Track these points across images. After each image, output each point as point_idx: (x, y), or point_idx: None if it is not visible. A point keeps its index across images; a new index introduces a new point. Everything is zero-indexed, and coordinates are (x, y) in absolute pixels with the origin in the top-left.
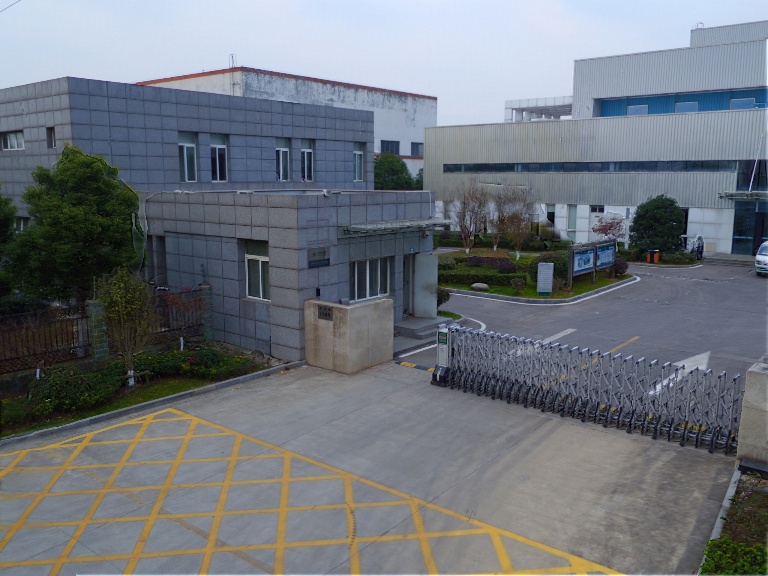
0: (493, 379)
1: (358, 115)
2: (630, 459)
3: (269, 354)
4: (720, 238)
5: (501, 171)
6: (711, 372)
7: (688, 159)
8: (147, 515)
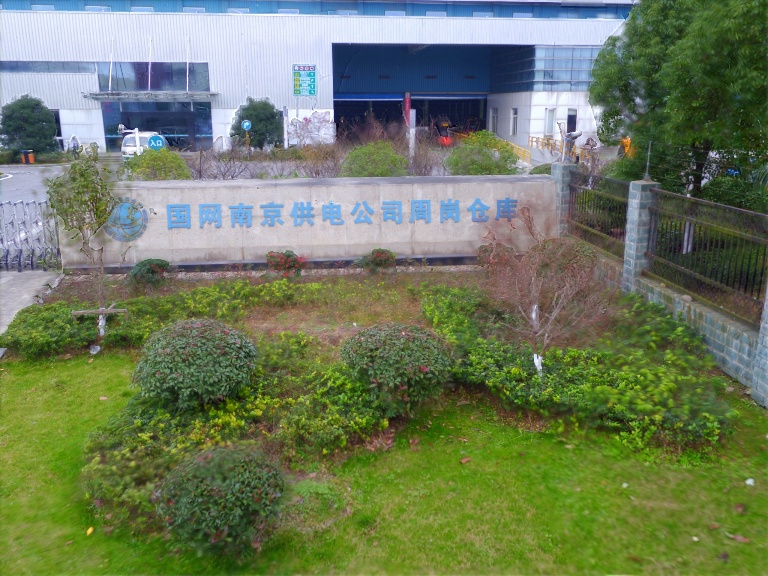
0: None
1: None
2: None
3: None
4: (94, 138)
5: None
6: (34, 203)
7: (48, 60)
8: None
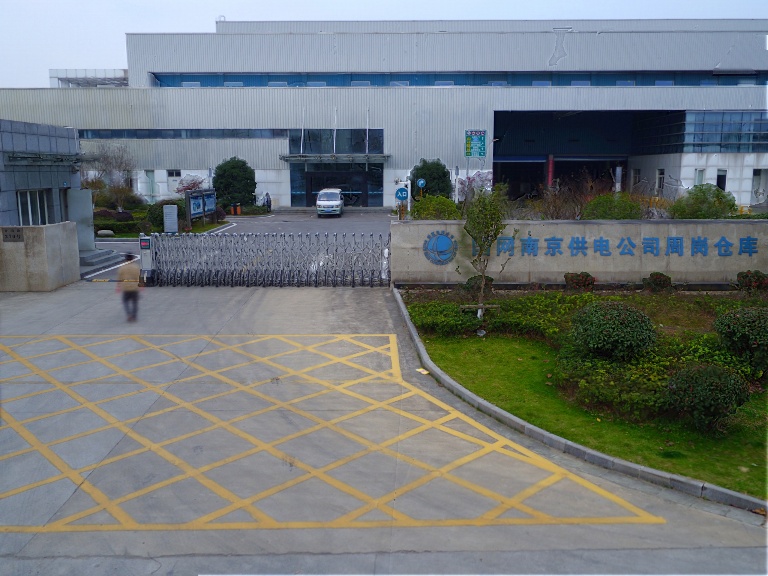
0: (197, 272)
1: None
2: (328, 296)
3: None
4: (281, 194)
5: None
6: None
7: (249, 128)
8: None
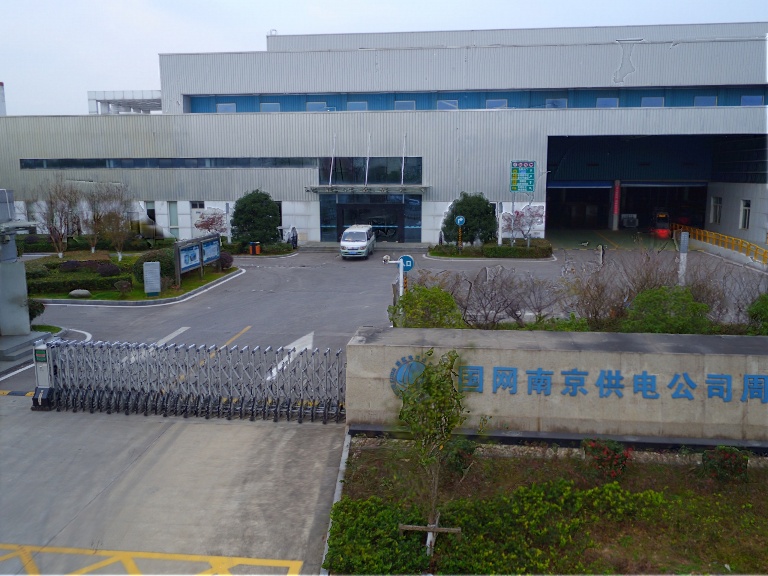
0: (106, 392)
1: None
2: (256, 446)
3: None
4: (310, 228)
5: (91, 167)
6: (318, 351)
7: (276, 156)
8: None
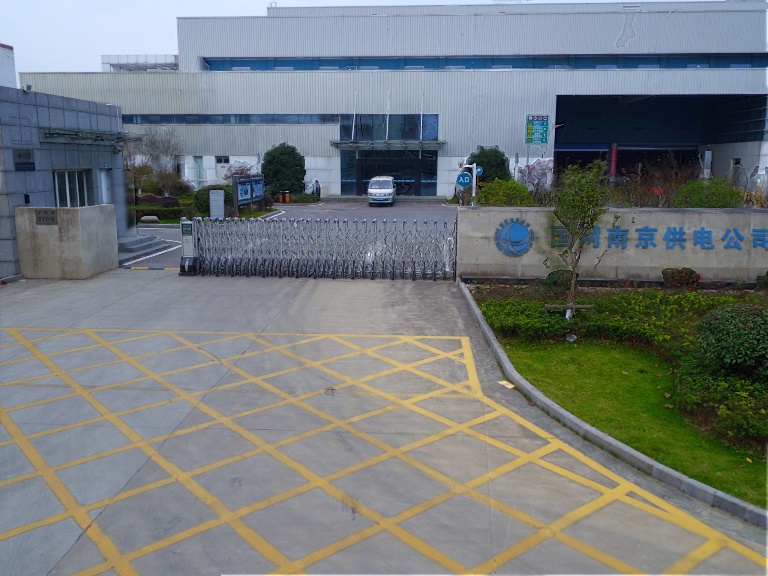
0: None
1: None
2: (387, 290)
3: None
4: (331, 182)
5: None
6: None
7: (299, 113)
8: None
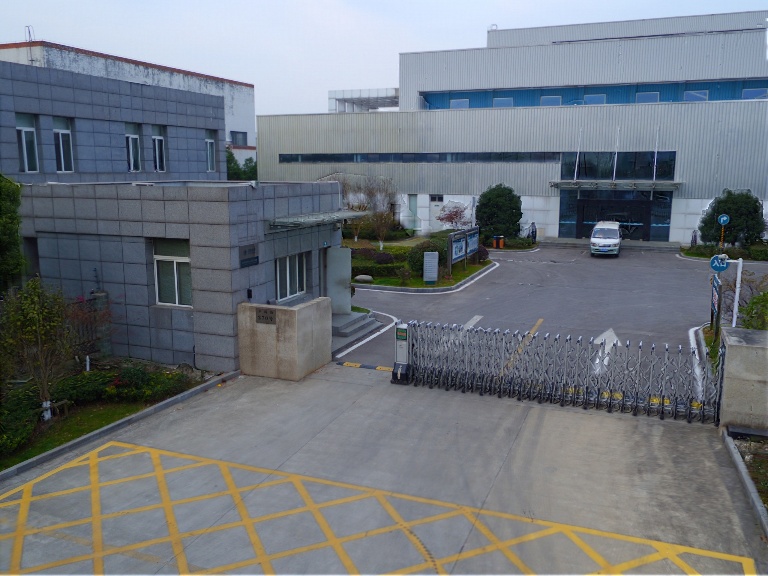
0: None
1: (208, 100)
2: (629, 438)
3: (193, 366)
4: (548, 223)
5: (340, 161)
6: None
7: (518, 151)
8: (176, 575)
